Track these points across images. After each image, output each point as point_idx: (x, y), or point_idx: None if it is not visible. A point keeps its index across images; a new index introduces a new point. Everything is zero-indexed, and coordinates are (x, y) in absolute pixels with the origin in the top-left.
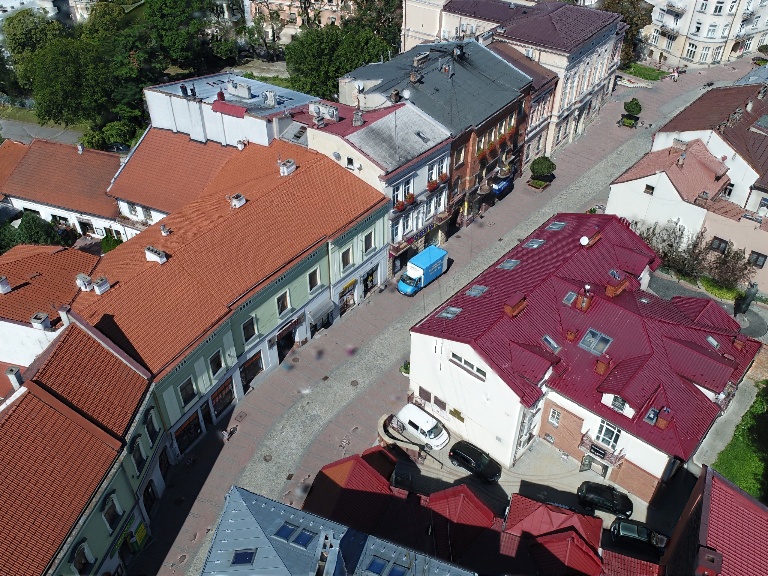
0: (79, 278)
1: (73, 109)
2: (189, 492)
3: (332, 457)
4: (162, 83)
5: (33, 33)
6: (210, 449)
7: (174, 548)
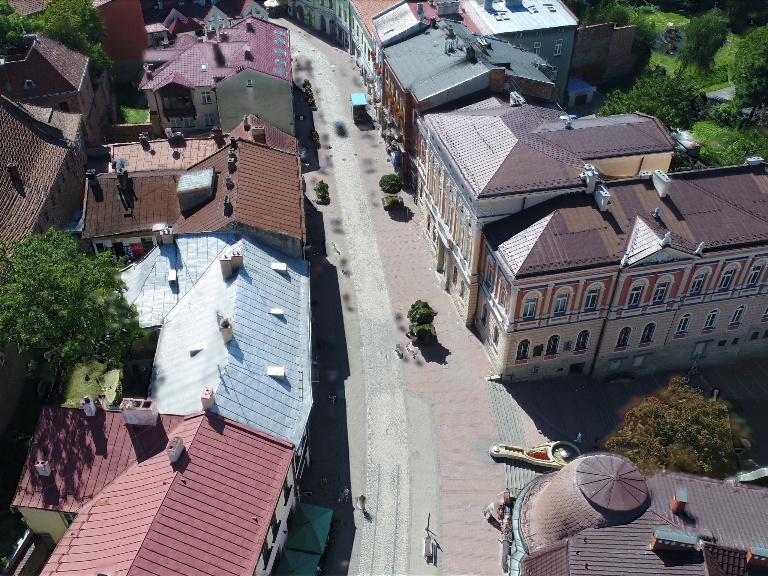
0: None
1: None
2: None
3: (295, 59)
4: None
5: None
6: (335, 44)
7: None
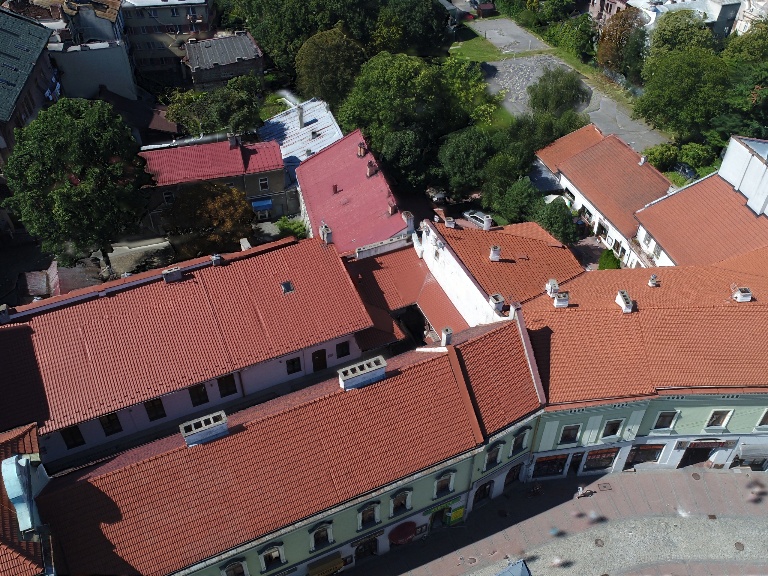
0: (551, 282)
1: (668, 117)
2: (516, 513)
3: None
4: (755, 137)
5: (681, 33)
6: (558, 492)
7: (473, 546)
